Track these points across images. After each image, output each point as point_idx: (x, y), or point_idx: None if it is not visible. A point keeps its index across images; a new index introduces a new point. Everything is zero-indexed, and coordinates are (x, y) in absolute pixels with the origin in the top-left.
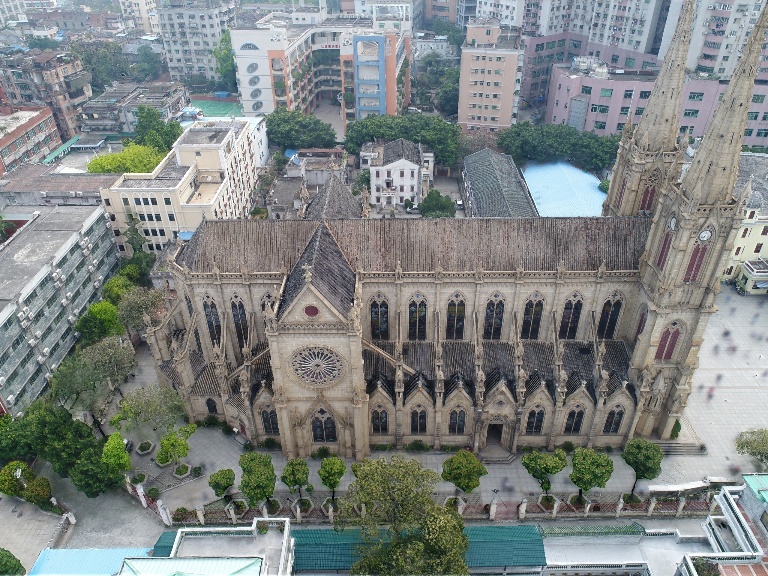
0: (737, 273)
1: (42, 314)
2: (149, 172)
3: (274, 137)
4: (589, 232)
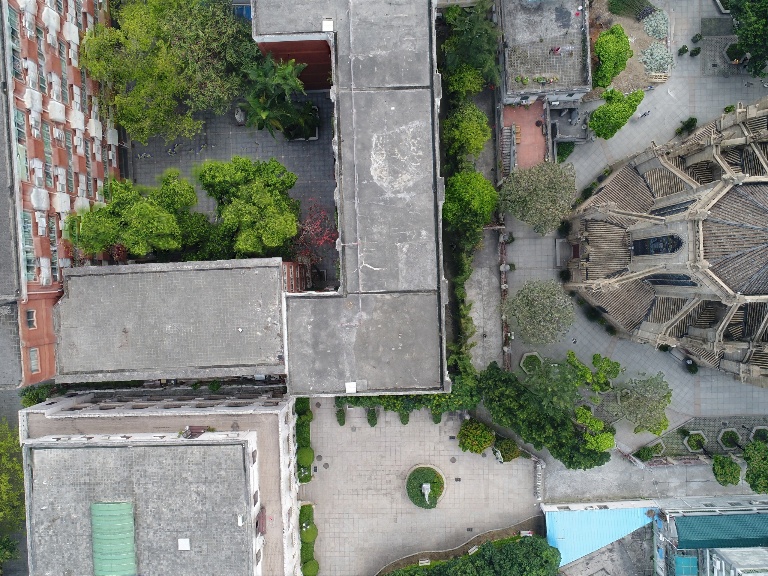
0: None
1: None
2: None
3: None
4: None
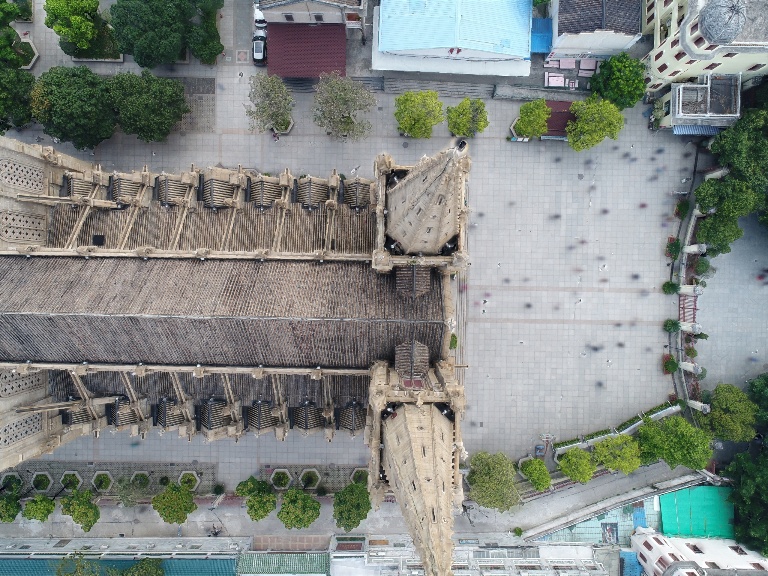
0: (668, 85)
1: None
2: None
3: None
4: (298, 333)
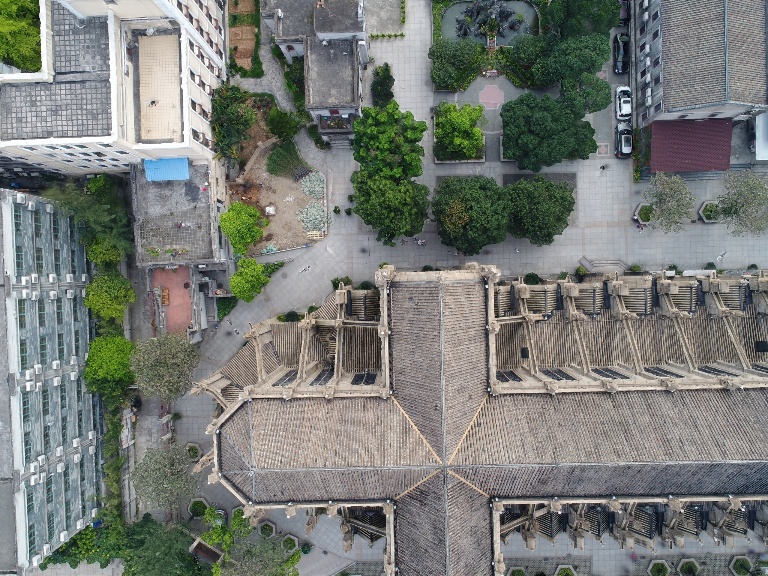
0: None
1: (47, 430)
2: (20, 6)
3: None
4: None
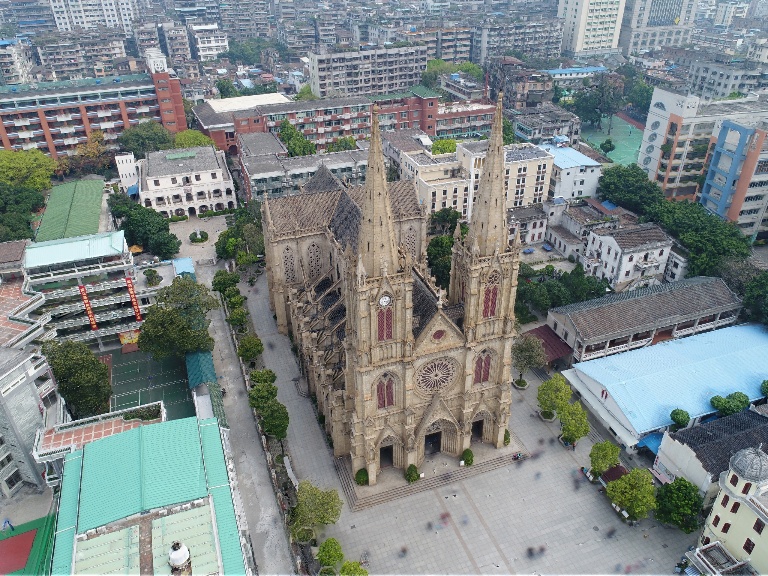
0: None
1: None
2: None
3: (601, 184)
4: None
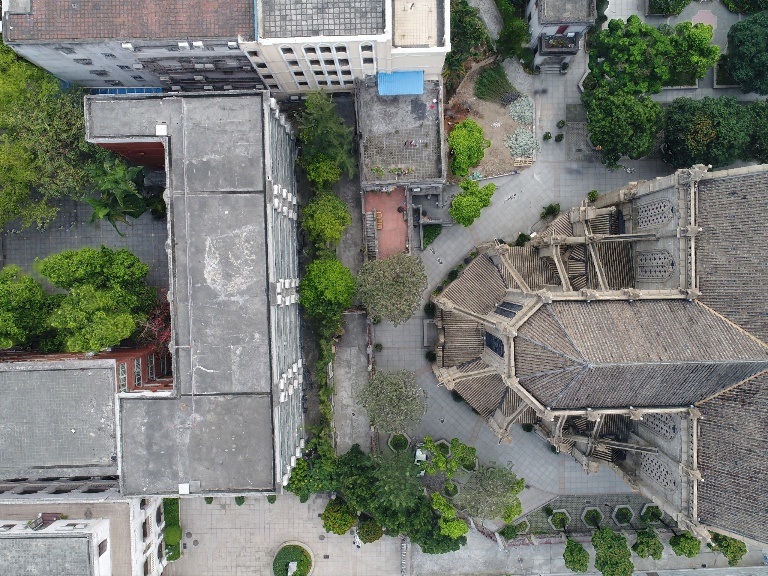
0: None
1: None
2: None
3: None
4: None
